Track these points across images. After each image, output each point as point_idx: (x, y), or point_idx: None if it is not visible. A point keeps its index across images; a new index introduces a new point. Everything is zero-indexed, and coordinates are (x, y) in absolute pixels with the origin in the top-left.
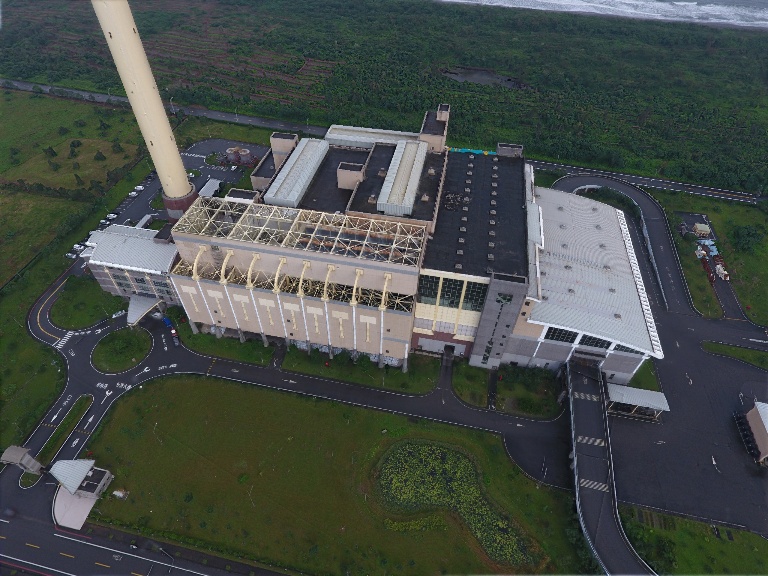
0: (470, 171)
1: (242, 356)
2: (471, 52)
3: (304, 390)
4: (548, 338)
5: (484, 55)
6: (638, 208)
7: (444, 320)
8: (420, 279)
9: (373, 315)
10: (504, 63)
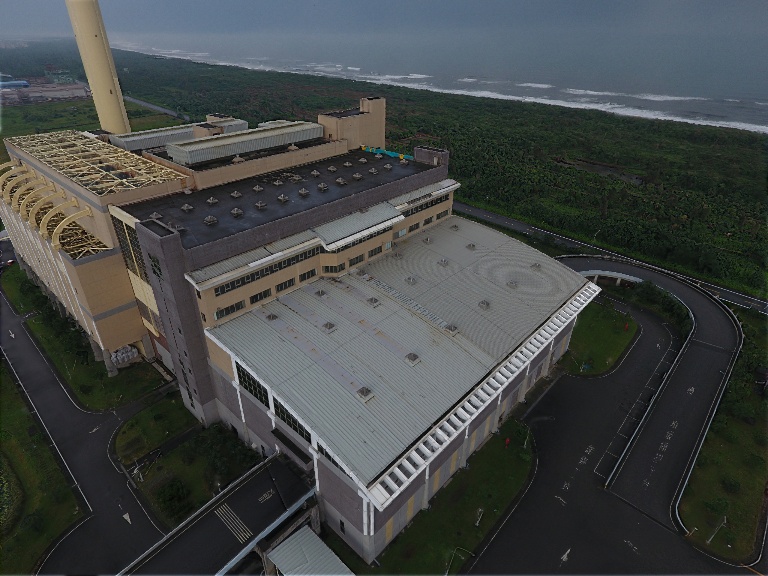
0: (349, 162)
1: (18, 298)
2: (602, 146)
3: (7, 347)
4: (243, 385)
5: (621, 153)
6: (689, 322)
7: (154, 309)
8: (114, 223)
9: (60, 259)
10: (644, 163)
